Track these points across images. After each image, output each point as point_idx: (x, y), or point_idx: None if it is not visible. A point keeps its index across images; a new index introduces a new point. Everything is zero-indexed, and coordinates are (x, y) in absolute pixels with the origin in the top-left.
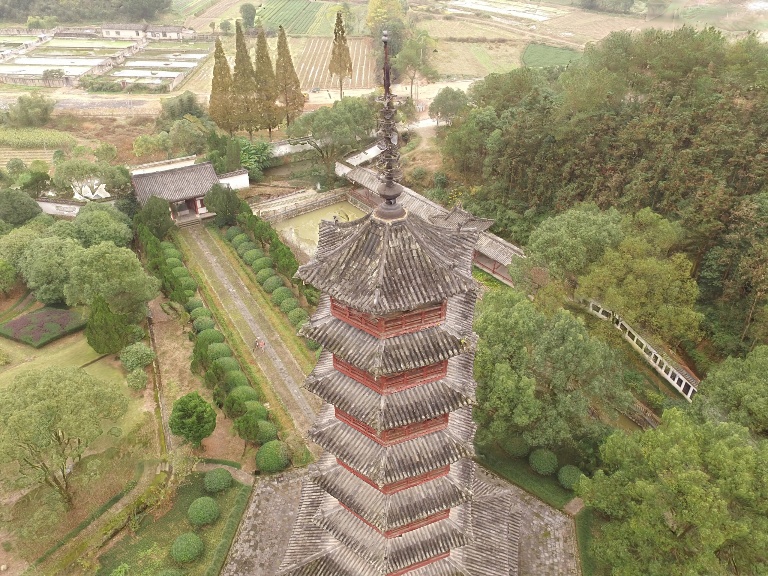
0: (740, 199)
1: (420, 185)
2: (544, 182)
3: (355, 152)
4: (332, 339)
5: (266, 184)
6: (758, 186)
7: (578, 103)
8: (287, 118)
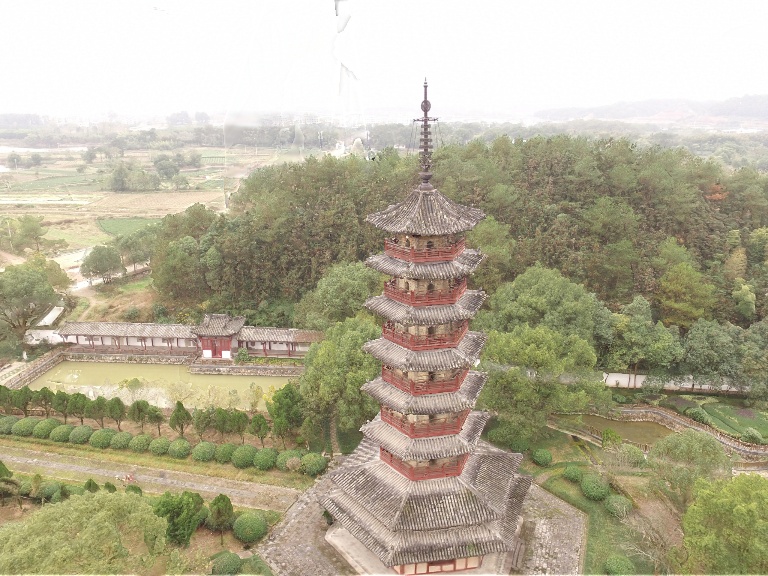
0: None
1: None
2: (268, 277)
3: (38, 319)
4: (425, 273)
5: None
6: None
7: (271, 214)
8: None
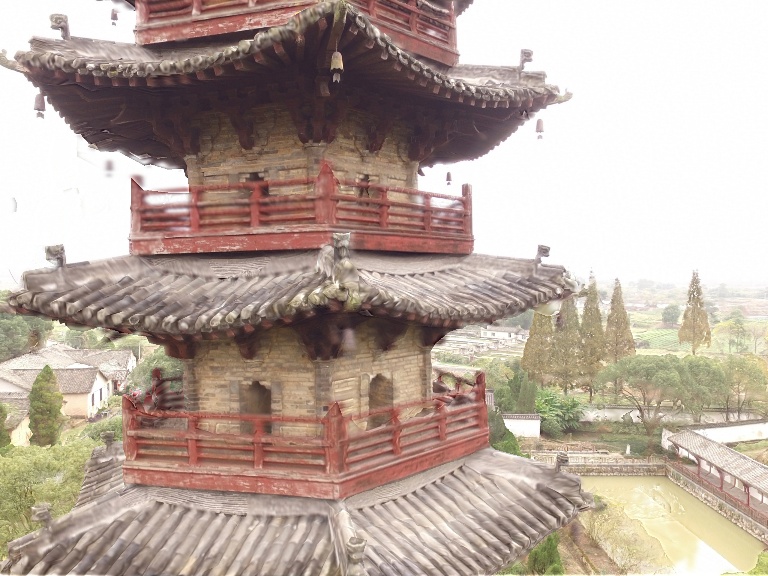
0: None
1: None
2: None
3: (696, 425)
4: None
5: (563, 441)
6: None
7: None
8: (615, 383)
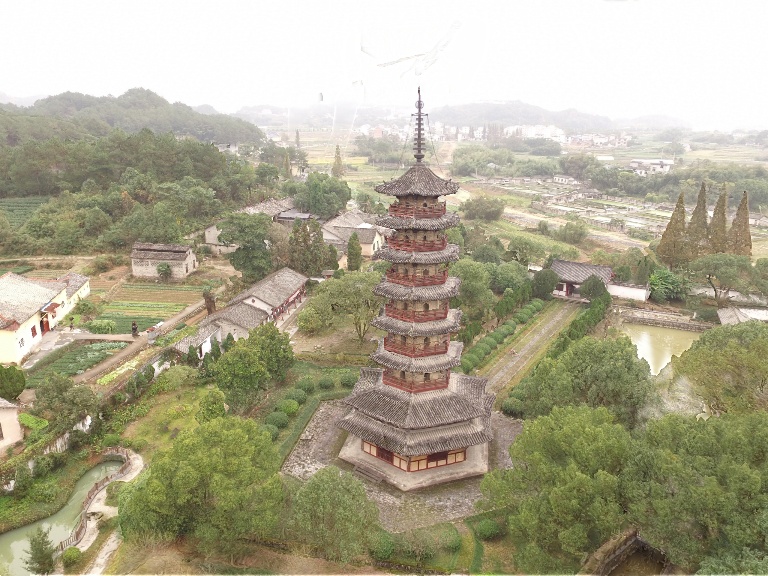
0: None
1: None
2: None
3: (762, 307)
4: None
5: (662, 305)
6: None
7: None
8: None
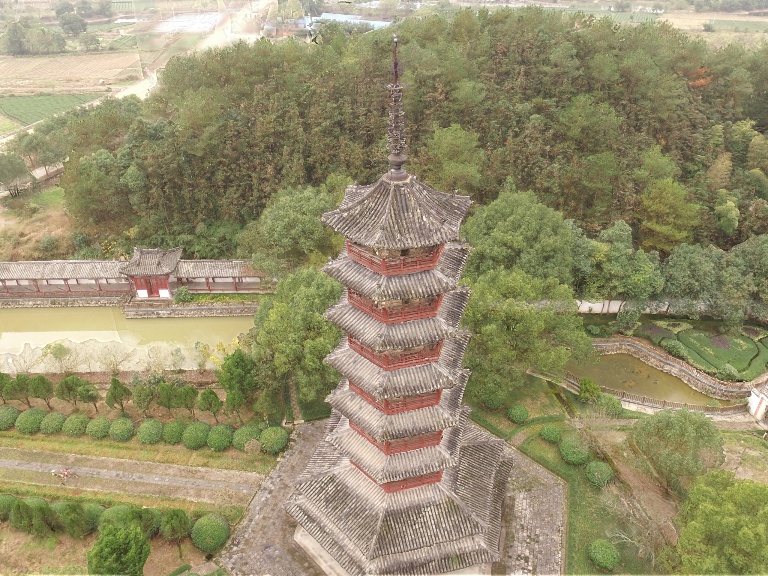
0: (369, 150)
1: (57, 255)
2: (203, 197)
3: None
4: (401, 291)
5: None
6: (372, 138)
7: (198, 120)
8: None
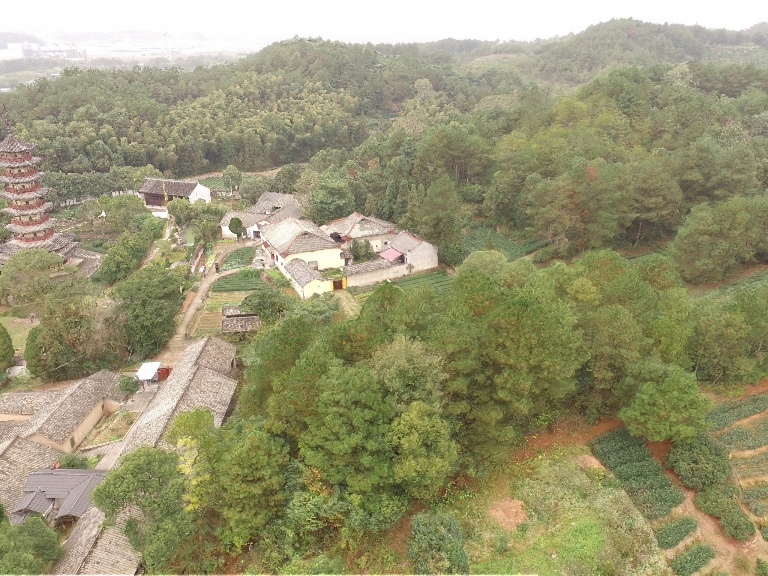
0: None
1: None
2: None
3: None
4: None
5: None
6: None
7: None
8: None
